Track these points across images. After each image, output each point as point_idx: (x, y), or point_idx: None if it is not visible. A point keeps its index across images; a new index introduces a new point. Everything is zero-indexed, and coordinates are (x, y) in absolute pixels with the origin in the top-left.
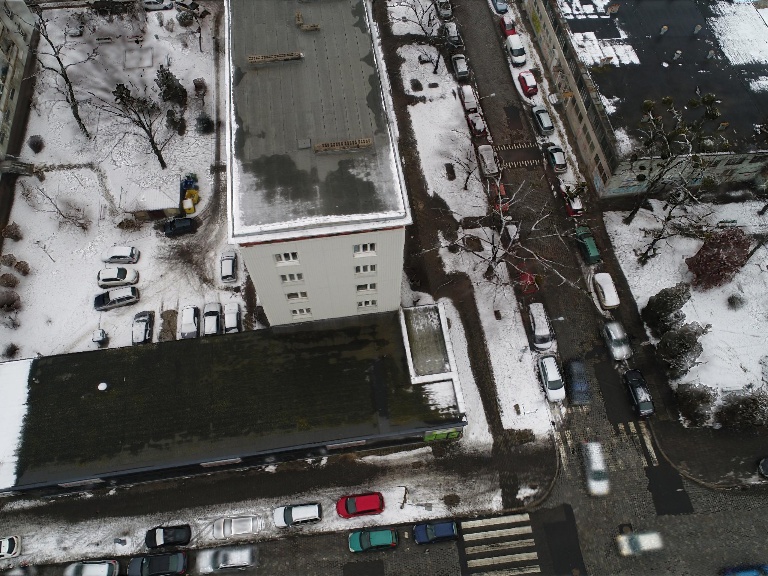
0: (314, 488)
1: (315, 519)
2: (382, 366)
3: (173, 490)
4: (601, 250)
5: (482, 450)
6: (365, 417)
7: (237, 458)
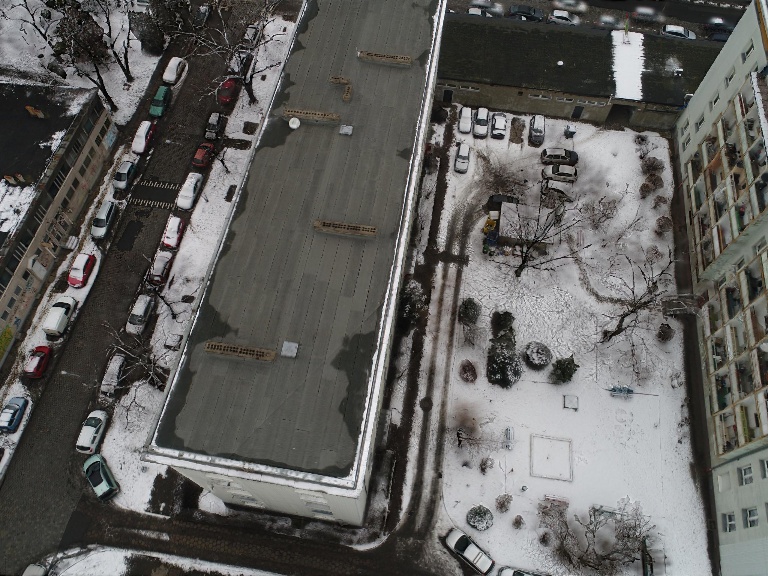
0: None
1: None
2: None
3: None
4: None
5: None
6: None
7: None
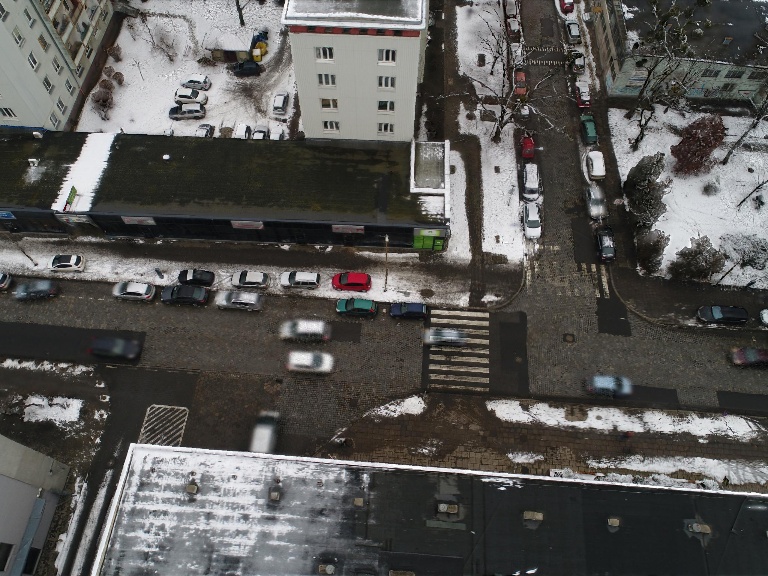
0: (317, 266)
1: (313, 283)
2: (389, 179)
3: (206, 249)
4: (600, 136)
5: (461, 263)
6: (367, 210)
7: (260, 222)
